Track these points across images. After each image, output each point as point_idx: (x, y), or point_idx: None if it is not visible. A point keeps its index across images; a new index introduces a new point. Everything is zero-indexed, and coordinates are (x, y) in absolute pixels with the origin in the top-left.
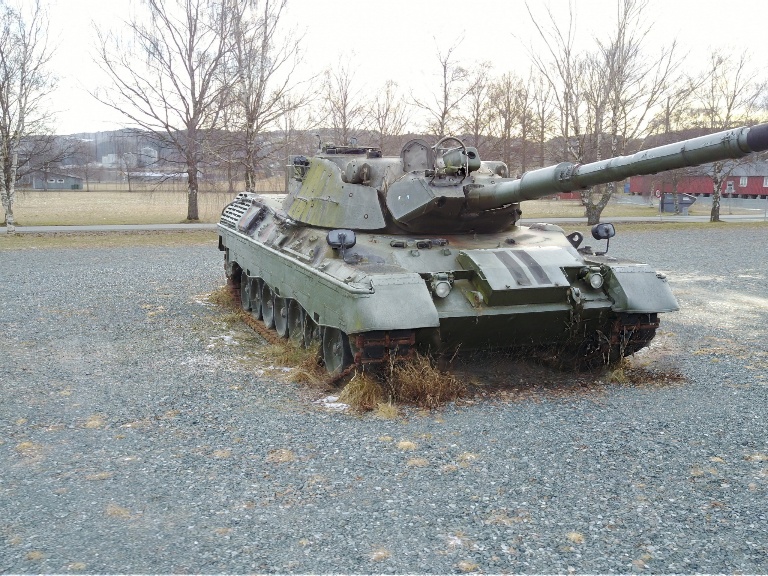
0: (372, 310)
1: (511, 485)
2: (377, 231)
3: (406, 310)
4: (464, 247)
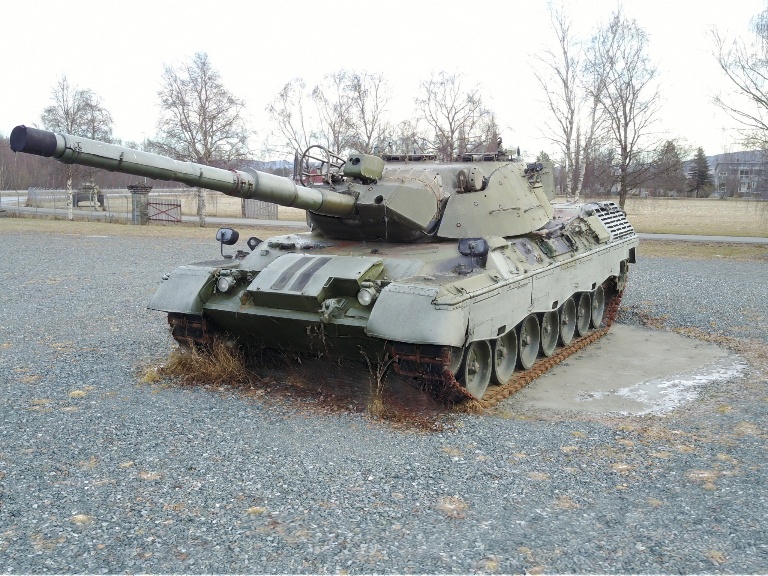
0: (156, 292)
1: (5, 424)
2: (319, 234)
3: (177, 296)
4: (320, 252)
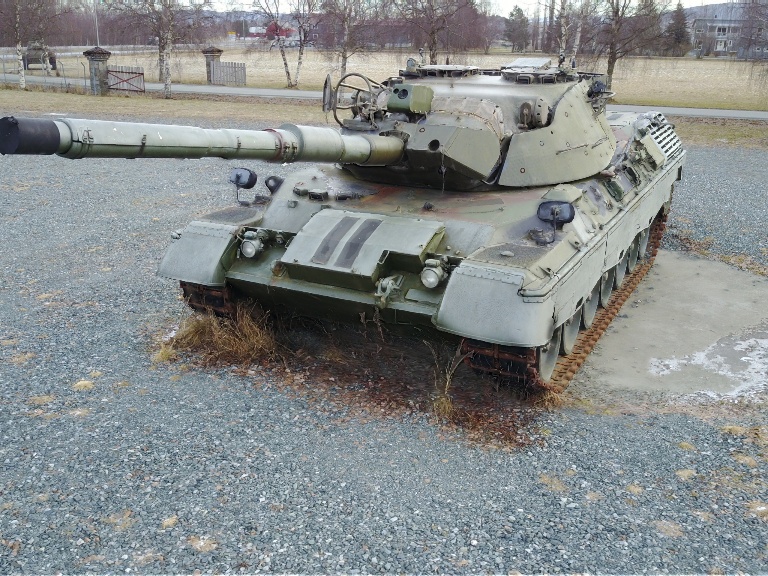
0: (166, 255)
1: (5, 445)
2: None
3: (193, 262)
4: (360, 205)
